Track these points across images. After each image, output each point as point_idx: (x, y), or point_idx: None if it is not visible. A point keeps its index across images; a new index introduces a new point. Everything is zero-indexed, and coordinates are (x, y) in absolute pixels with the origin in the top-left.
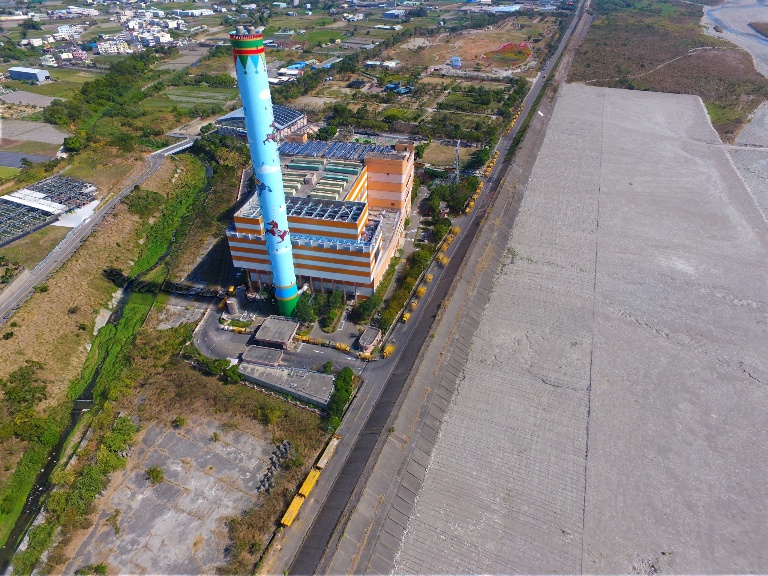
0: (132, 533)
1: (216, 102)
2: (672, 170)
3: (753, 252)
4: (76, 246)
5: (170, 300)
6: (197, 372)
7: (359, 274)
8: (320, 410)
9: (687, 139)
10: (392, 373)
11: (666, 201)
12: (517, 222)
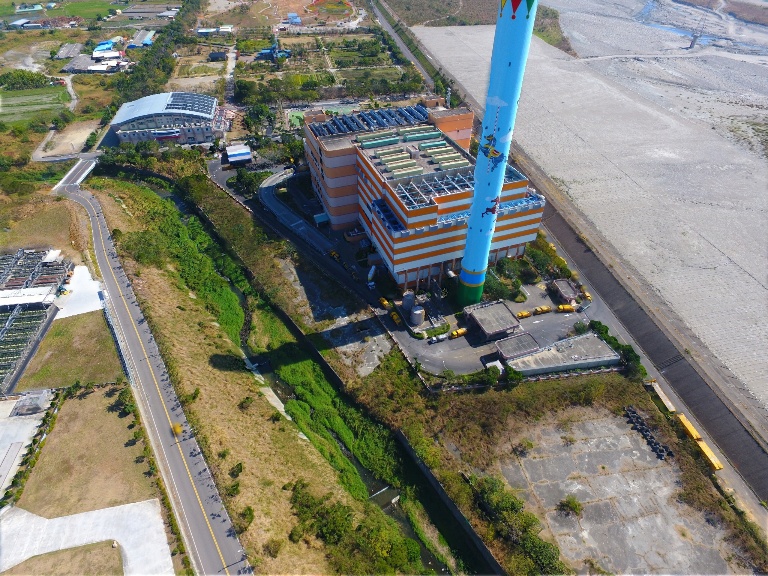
0: (626, 568)
1: (48, 107)
2: (573, 85)
3: (688, 132)
4: (143, 330)
5: (330, 342)
6: (468, 394)
7: (528, 233)
8: (614, 367)
9: (552, 59)
10: (613, 311)
11: (600, 110)
12: (530, 154)
